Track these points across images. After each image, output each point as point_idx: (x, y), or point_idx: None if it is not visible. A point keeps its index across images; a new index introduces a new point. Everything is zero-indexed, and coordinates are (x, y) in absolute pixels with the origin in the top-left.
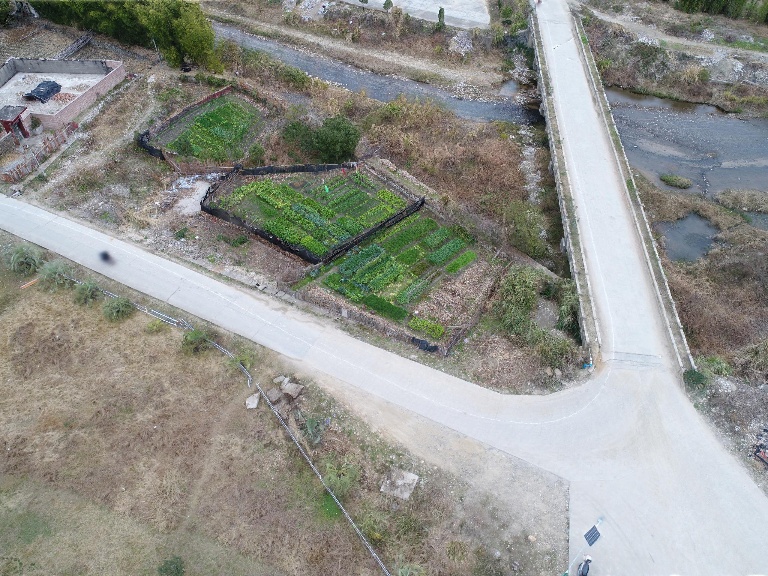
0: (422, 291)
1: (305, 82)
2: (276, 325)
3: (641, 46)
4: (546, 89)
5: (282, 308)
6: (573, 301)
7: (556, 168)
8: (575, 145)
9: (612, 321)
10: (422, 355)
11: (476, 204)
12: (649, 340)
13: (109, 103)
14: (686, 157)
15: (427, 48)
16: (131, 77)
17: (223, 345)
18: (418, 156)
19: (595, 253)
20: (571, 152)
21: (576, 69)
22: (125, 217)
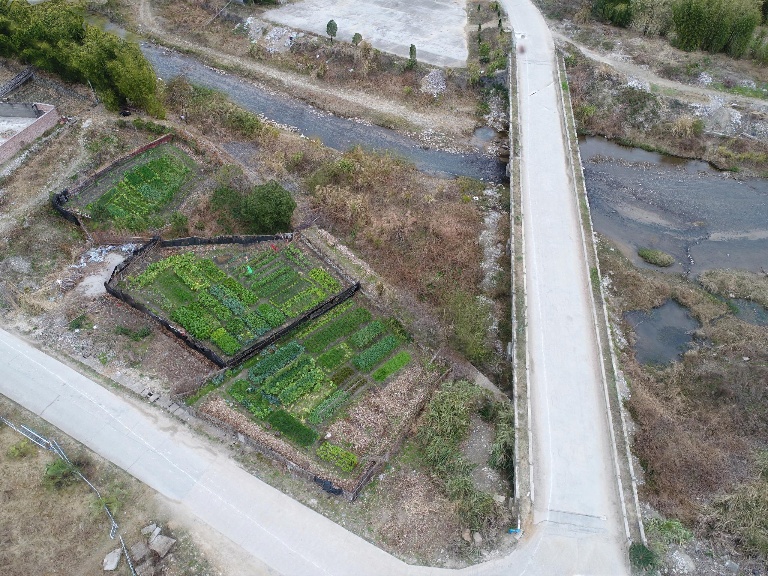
0: (340, 406)
1: (255, 129)
2: (160, 451)
3: (629, 91)
4: (514, 147)
5: (172, 427)
6: (507, 438)
7: (512, 250)
8: (538, 219)
9: (552, 464)
10: (324, 499)
11: (421, 288)
12: (594, 493)
13: (34, 153)
14: (670, 226)
15: (396, 88)
16: (65, 121)
17: (94, 477)
18: (365, 224)
19: (543, 366)
20: (532, 228)
21: (552, 121)
22: (16, 301)
